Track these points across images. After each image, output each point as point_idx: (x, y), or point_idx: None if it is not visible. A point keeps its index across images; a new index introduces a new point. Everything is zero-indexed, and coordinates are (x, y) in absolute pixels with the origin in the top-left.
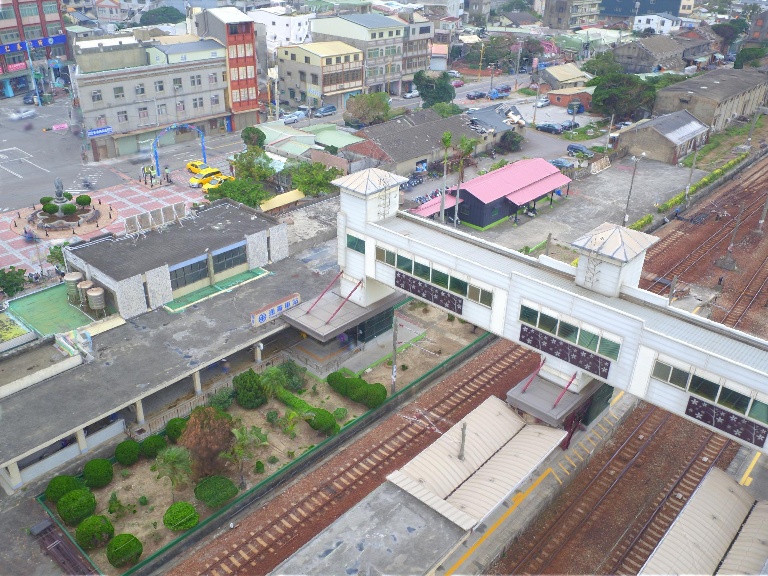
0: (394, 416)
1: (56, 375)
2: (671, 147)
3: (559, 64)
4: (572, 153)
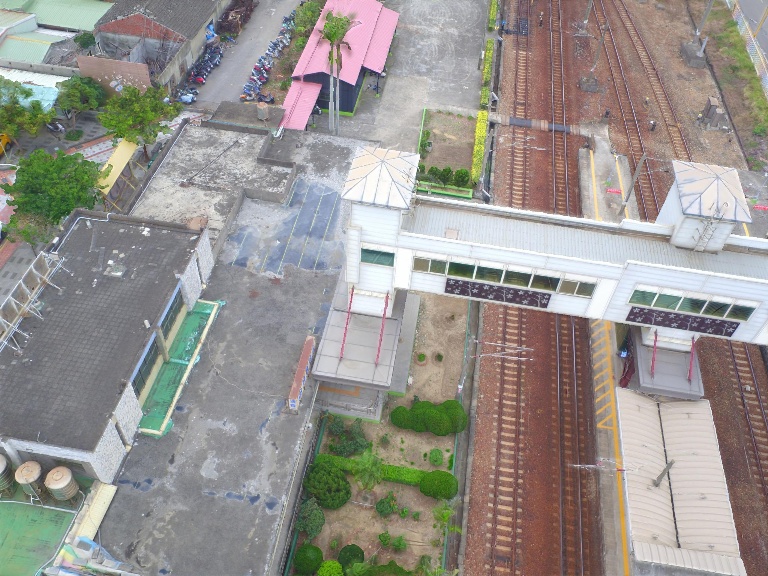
0: (478, 426)
1: None
2: None
3: None
4: None
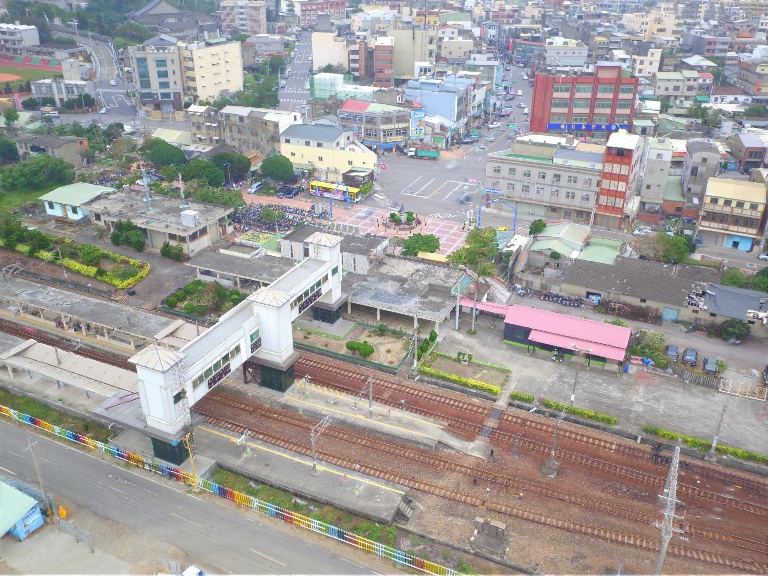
0: None
1: None
2: None
3: None
4: (764, 372)
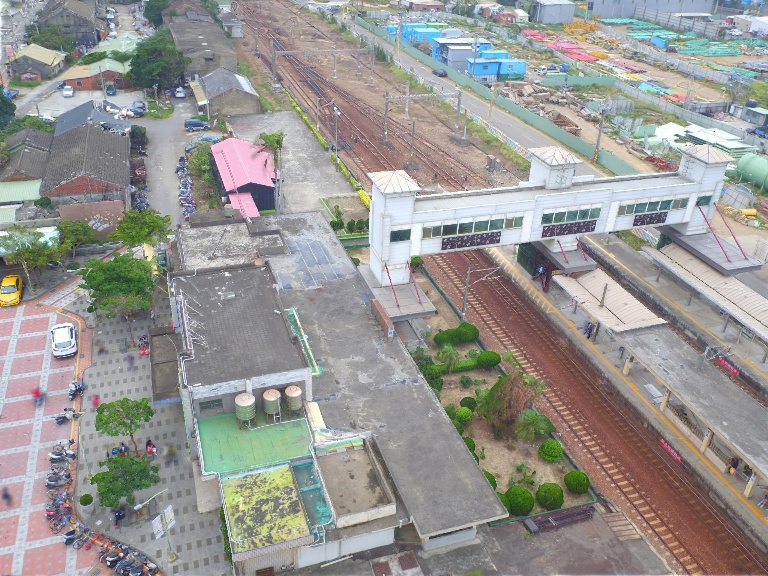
0: (483, 337)
1: None
2: (256, 100)
3: (19, 47)
4: (192, 129)
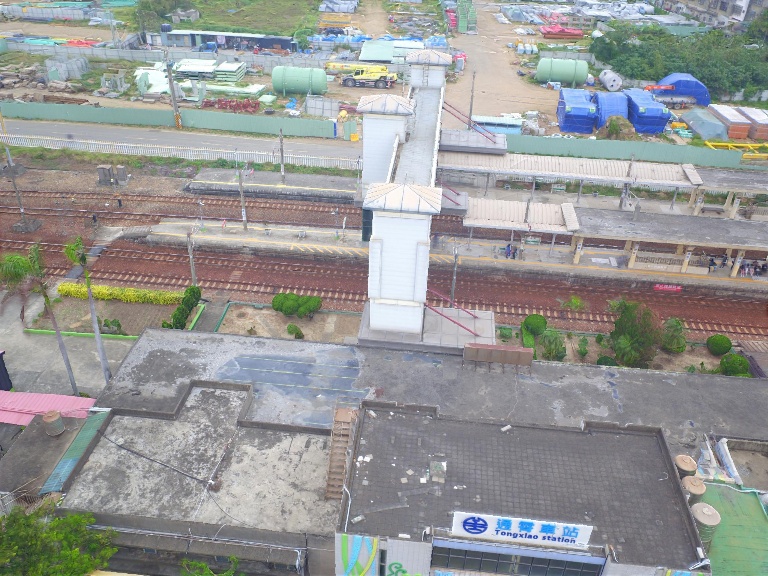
0: None
1: (750, 440)
2: None
3: None
4: None
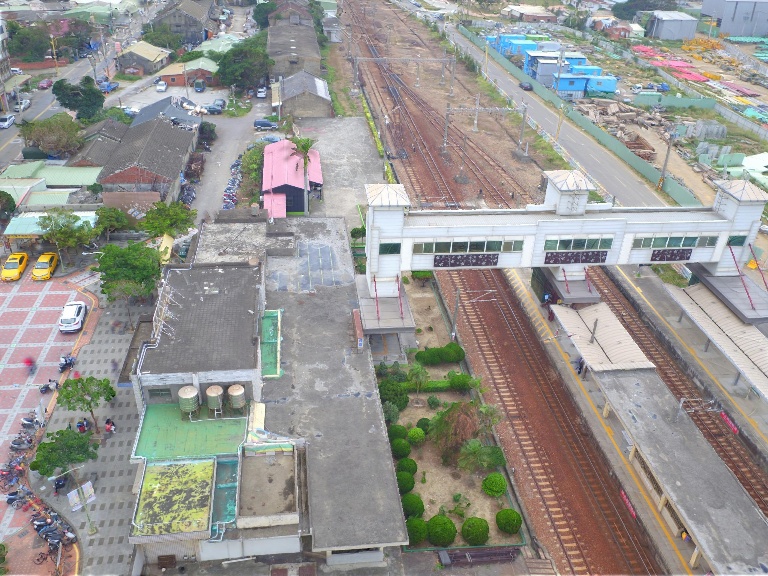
0: (471, 359)
1: None
2: (328, 104)
3: (129, 43)
4: (261, 128)
